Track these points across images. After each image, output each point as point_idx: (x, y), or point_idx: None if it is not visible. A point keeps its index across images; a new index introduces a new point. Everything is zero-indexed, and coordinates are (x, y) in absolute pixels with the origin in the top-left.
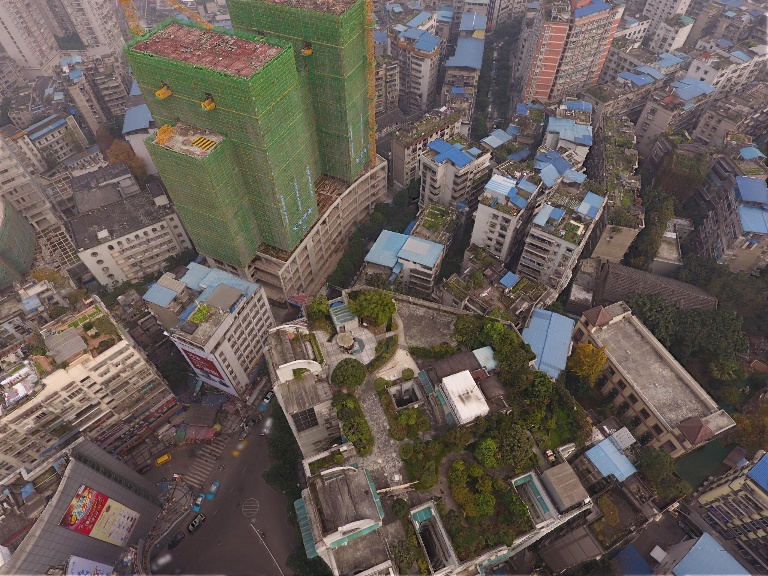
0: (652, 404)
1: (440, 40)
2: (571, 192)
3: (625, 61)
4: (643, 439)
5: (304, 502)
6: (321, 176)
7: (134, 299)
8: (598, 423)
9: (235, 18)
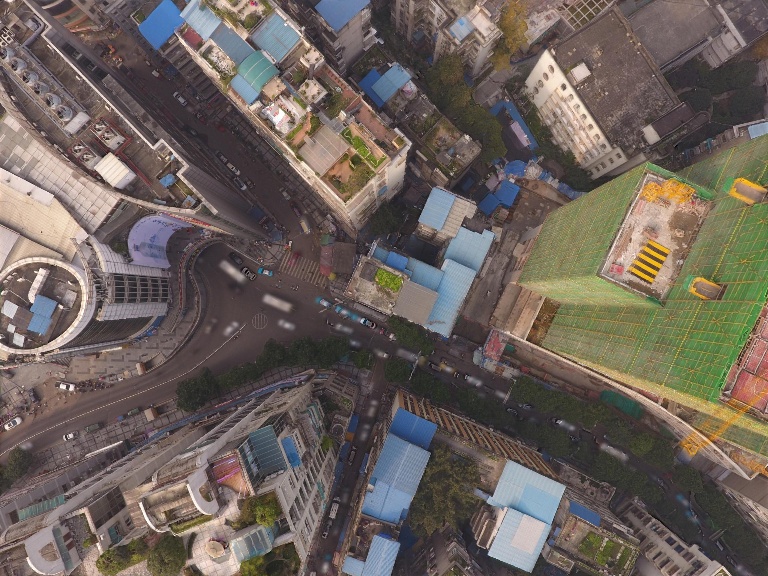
0: None
1: None
2: None
3: None
4: None
5: (43, 517)
6: None
7: (464, 156)
8: None
9: None
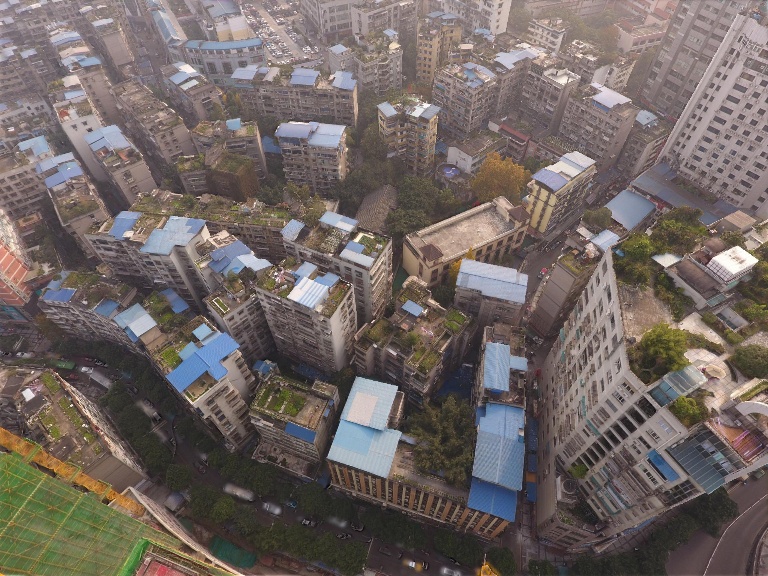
0: None
1: None
2: None
3: (2, 182)
4: None
5: None
6: None
7: None
8: None
9: None
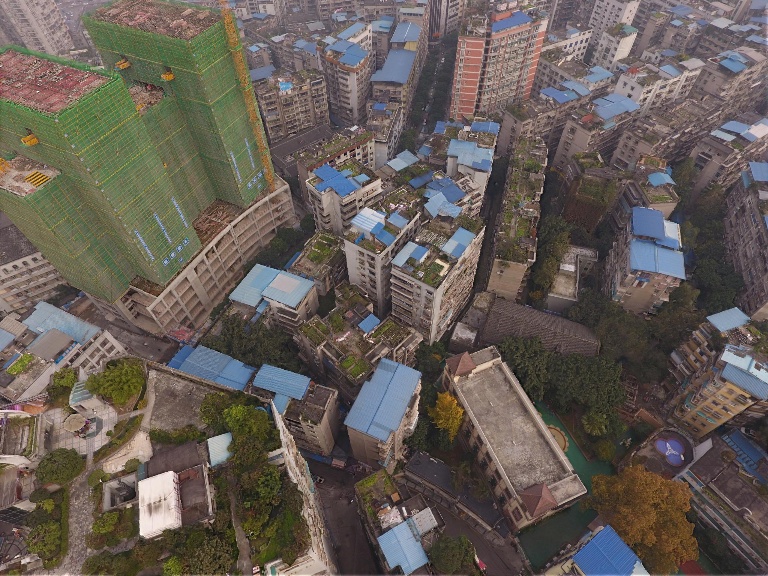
0: (505, 465)
1: (367, 53)
2: (445, 227)
3: (556, 75)
4: (501, 500)
5: None
6: (216, 201)
7: None
8: None
9: (96, 41)
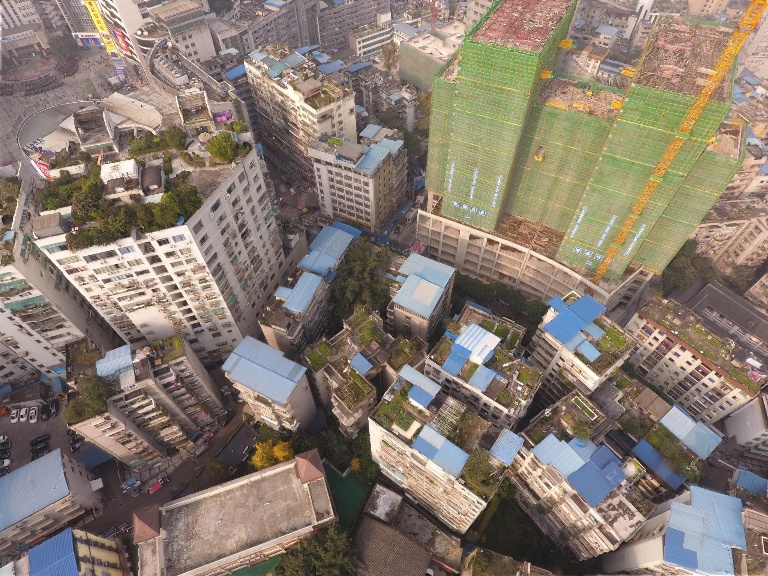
0: (201, 506)
1: None
2: None
3: None
4: None
5: None
6: None
7: None
8: (156, 374)
9: None
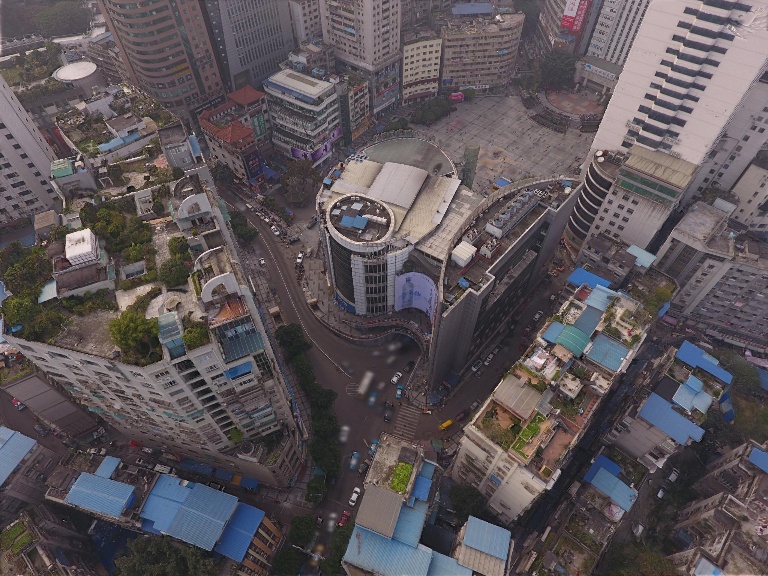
0: None
1: None
2: None
3: None
4: None
5: None
6: None
7: None
8: None
9: None
